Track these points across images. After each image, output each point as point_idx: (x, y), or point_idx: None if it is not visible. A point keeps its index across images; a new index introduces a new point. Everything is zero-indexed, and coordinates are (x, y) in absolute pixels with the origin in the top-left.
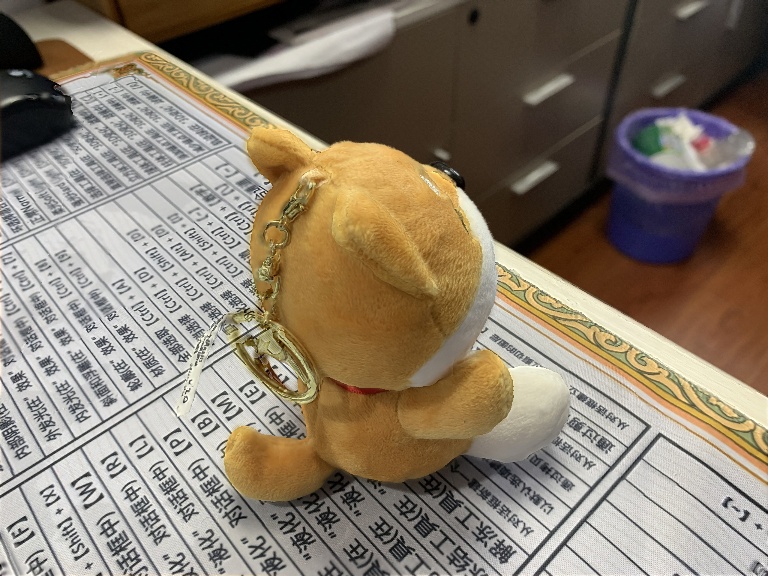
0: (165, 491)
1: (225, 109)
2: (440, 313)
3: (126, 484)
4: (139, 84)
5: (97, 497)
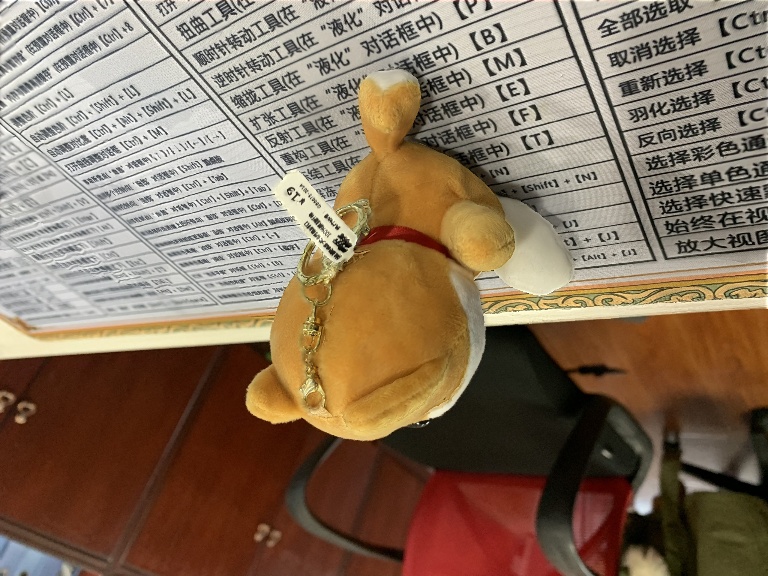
0: None
1: None
2: None
3: None
4: None
5: None
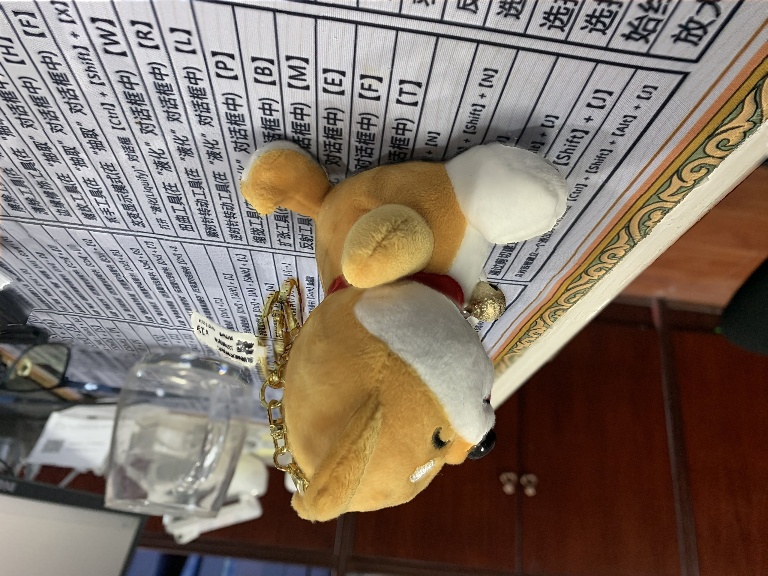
0: (192, 94)
1: None
2: None
3: (154, 62)
4: None
5: (120, 51)
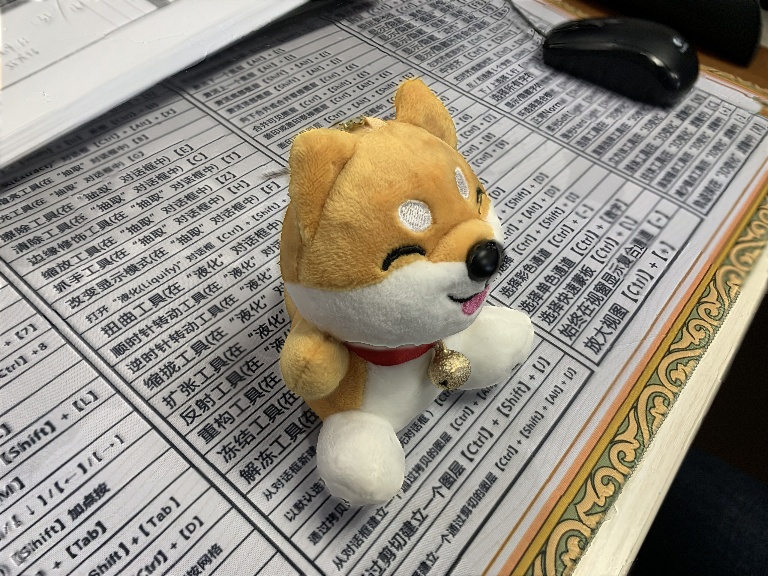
0: None
1: (767, 202)
2: (303, 258)
3: None
4: (763, 132)
5: None
